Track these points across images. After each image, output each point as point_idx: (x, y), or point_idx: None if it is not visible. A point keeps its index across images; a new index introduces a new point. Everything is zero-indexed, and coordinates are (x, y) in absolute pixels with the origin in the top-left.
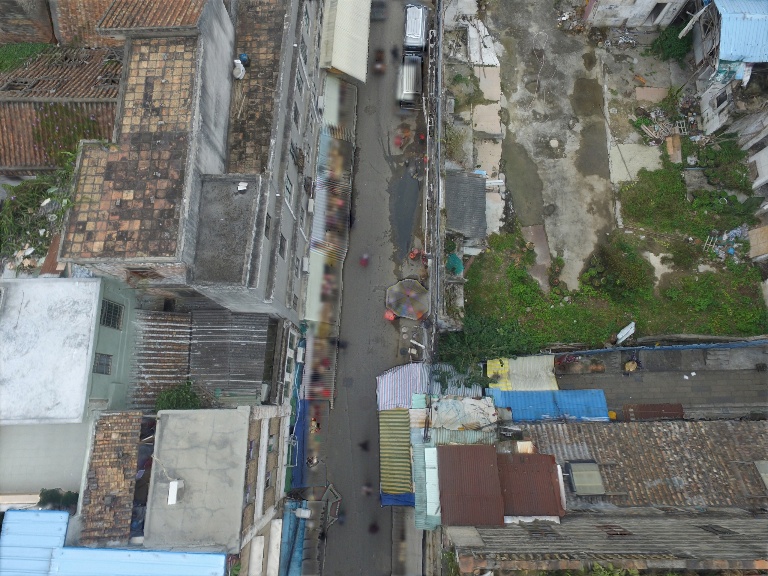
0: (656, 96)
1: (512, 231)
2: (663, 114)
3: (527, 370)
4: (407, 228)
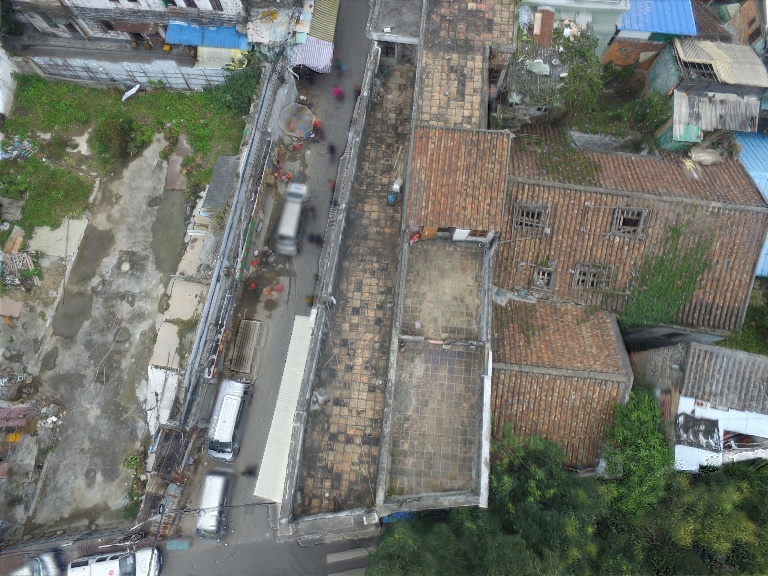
0: (2, 304)
1: (195, 187)
2: (6, 280)
3: (216, 62)
4: (288, 203)
